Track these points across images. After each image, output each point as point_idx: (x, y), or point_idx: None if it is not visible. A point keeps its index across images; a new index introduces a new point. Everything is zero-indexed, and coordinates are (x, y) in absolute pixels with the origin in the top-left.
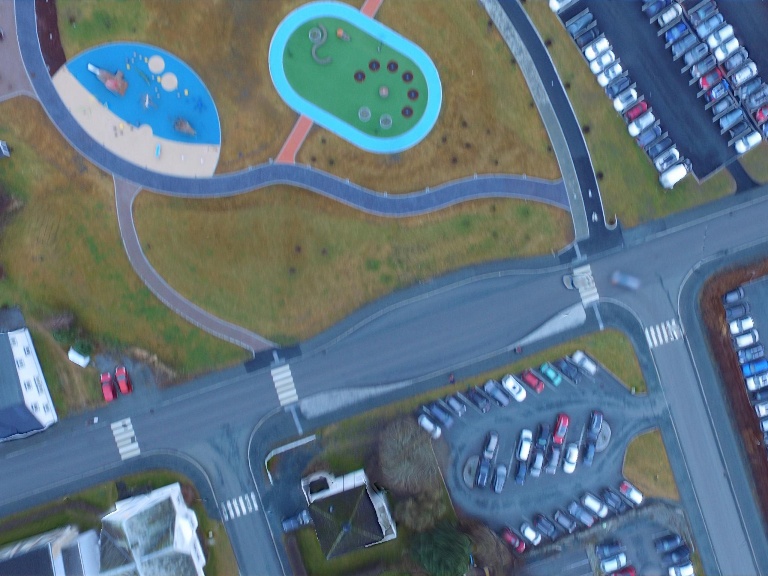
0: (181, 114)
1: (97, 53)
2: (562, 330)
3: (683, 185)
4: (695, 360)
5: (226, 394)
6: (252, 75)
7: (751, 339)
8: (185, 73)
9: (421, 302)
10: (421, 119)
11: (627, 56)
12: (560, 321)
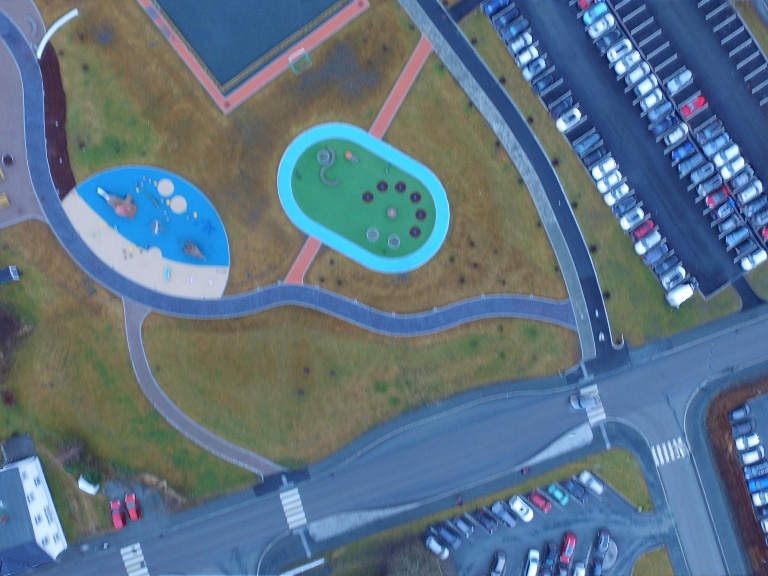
0: (190, 237)
1: (107, 177)
2: (569, 450)
3: (689, 302)
4: (701, 478)
5: (235, 518)
6: (261, 197)
7: (757, 456)
8: (194, 196)
9: (429, 424)
10: (429, 239)
11: (634, 175)
12: (567, 441)
